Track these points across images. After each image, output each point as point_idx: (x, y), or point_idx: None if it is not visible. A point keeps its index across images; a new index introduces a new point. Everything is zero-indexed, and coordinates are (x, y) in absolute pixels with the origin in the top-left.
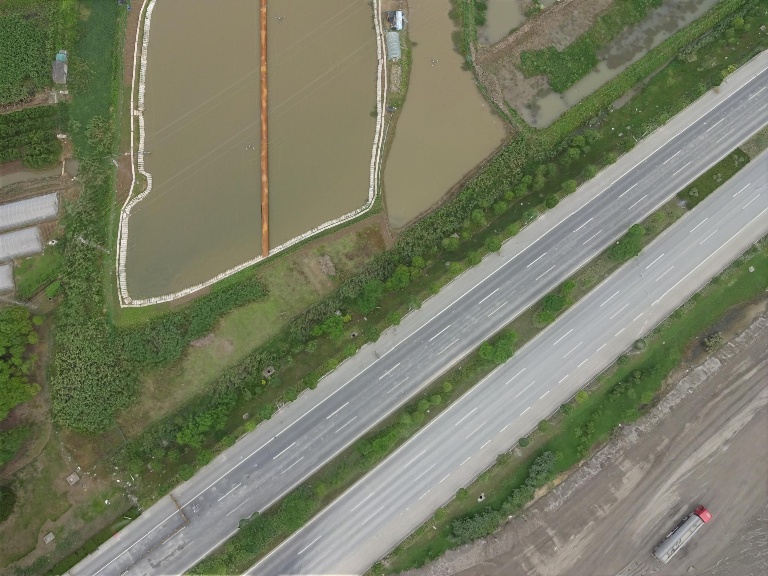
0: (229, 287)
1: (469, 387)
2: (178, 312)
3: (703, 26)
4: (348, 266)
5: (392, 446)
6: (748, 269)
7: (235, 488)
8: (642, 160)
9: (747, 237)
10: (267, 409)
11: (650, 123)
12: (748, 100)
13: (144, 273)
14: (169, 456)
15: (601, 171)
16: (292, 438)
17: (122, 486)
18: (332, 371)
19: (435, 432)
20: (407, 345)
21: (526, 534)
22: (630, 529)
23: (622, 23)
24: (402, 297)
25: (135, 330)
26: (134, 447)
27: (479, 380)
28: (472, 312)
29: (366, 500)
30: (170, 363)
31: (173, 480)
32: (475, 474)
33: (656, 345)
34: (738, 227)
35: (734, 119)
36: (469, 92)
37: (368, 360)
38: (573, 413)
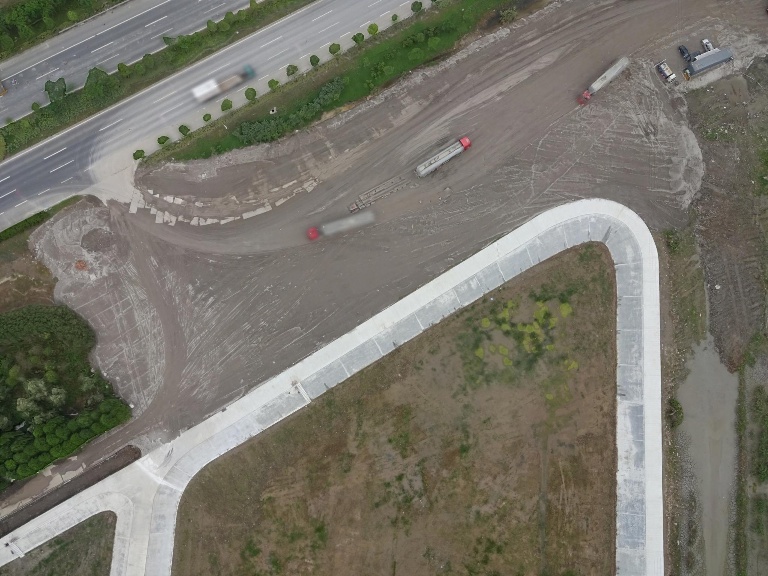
0: None
1: (278, 17)
2: None
3: None
4: None
5: (199, 55)
6: None
7: (53, 71)
8: None
9: None
10: None
11: None
12: None
13: None
14: None
15: None
16: (111, 38)
17: None
18: None
19: (241, 50)
20: None
21: (307, 143)
22: (400, 151)
23: None
24: None
25: None
26: None
27: (288, 13)
28: None
29: (168, 96)
30: None
31: None
32: None
33: (455, 9)
34: None
35: None
36: None
37: None
38: (367, 51)
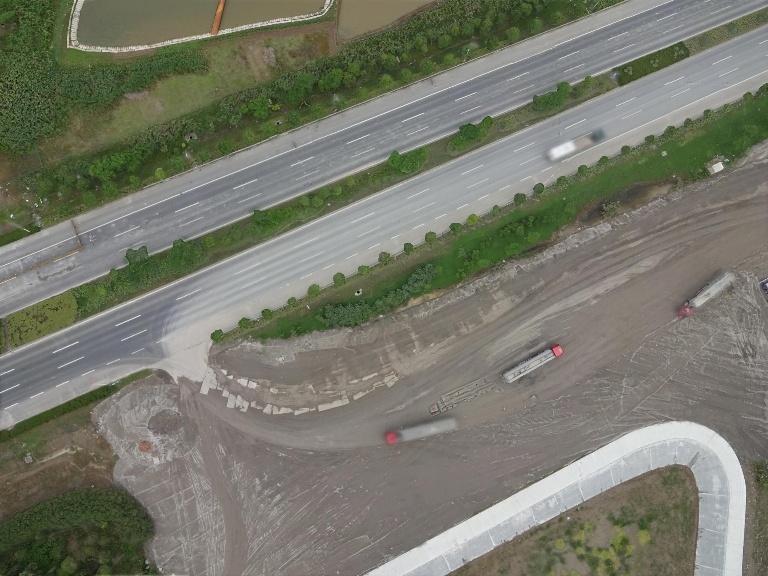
0: (173, 54)
1: (372, 192)
2: (120, 65)
3: None
4: (289, 62)
5: (287, 226)
6: (661, 153)
7: (133, 229)
8: (589, 32)
9: (668, 123)
10: (178, 159)
11: None
12: (704, 2)
13: (96, 23)
14: (78, 183)
15: (548, 32)
16: (197, 198)
17: (29, 206)
18: (249, 148)
19: (331, 224)
20: (325, 142)
21: (391, 332)
22: (487, 350)
23: None
24: (332, 101)
25: (75, 71)
26: (49, 174)
27: (383, 188)
28: (393, 128)
29: (251, 268)
30: (101, 107)
31: (77, 208)
32: None
33: (556, 198)
34: (662, 113)
35: (686, 16)
36: None
37: (285, 147)
38: (462, 238)
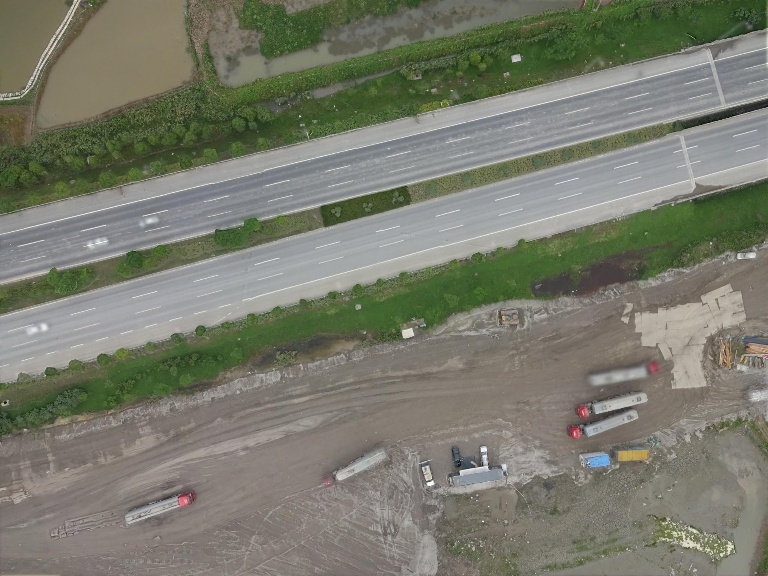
0: None
1: (34, 303)
2: None
3: (444, 47)
4: None
5: None
6: (355, 306)
7: None
8: (306, 159)
9: (368, 275)
10: None
11: (331, 125)
12: (445, 143)
13: None
14: None
15: (260, 153)
16: None
17: None
18: None
19: None
20: None
21: (28, 449)
22: (121, 484)
23: (366, 10)
24: (14, 195)
25: None
26: None
27: (46, 301)
28: (70, 236)
29: None
30: None
31: None
32: (6, 381)
33: (229, 338)
34: (365, 263)
35: (420, 156)
36: (175, 19)
37: None
38: None
